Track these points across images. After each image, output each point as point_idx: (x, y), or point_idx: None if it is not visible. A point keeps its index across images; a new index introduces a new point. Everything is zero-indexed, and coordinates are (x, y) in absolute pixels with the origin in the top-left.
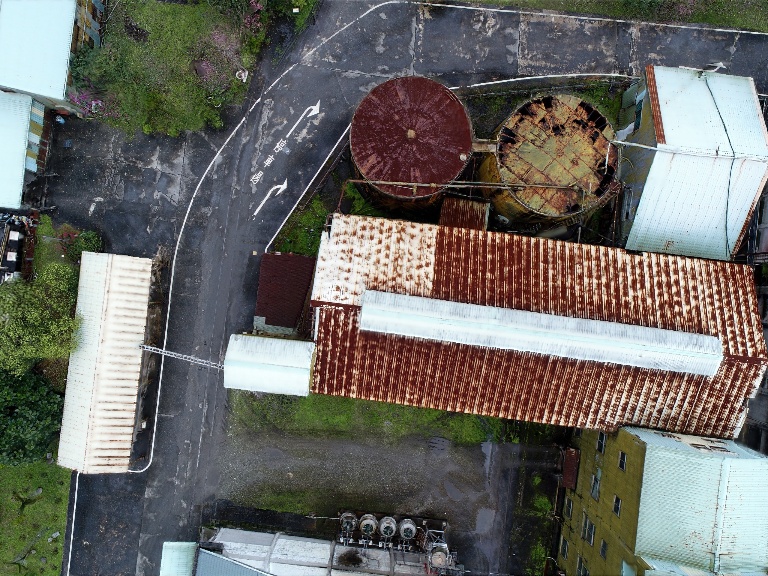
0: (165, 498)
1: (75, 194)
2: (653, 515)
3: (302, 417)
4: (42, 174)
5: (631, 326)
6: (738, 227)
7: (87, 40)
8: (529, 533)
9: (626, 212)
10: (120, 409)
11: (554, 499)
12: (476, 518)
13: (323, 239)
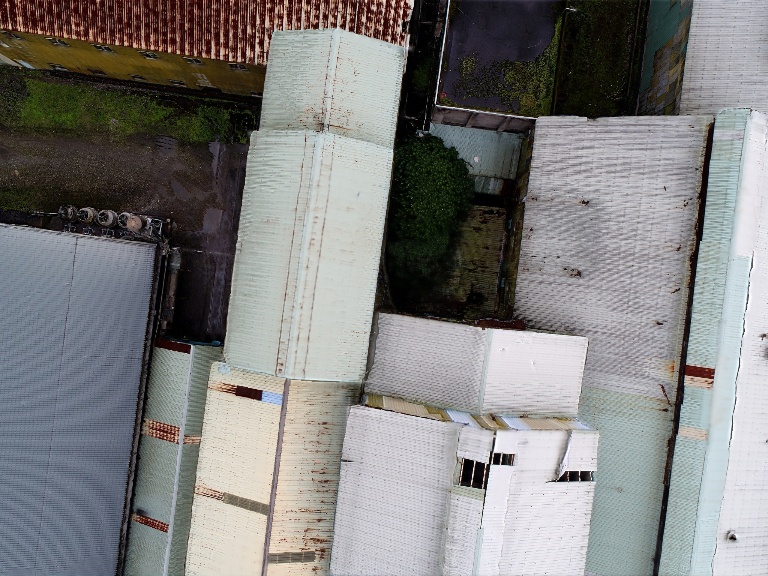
0: None
1: None
2: (275, 99)
3: (28, 115)
4: None
5: None
6: None
7: None
8: None
9: None
10: None
11: None
12: (203, 218)
13: None
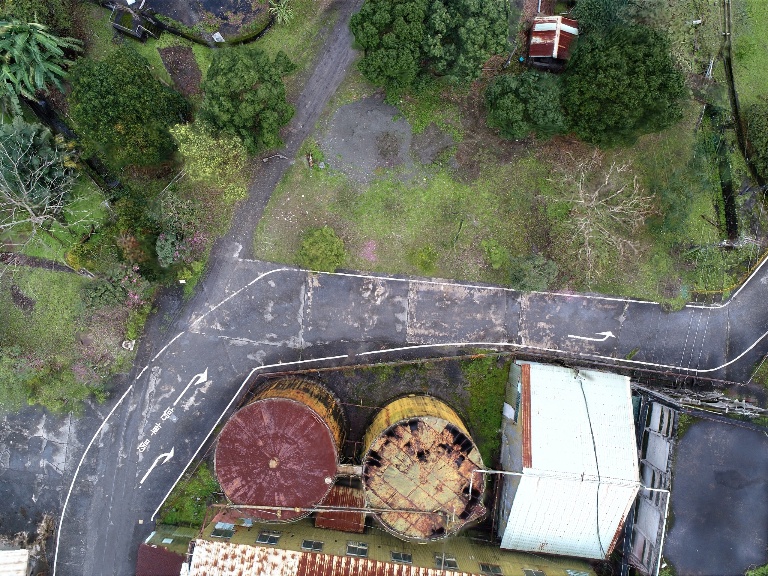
0: None
1: None
2: None
3: None
4: None
5: None
6: (610, 534)
7: None
8: None
9: (502, 509)
10: None
11: None
12: None
13: (183, 572)
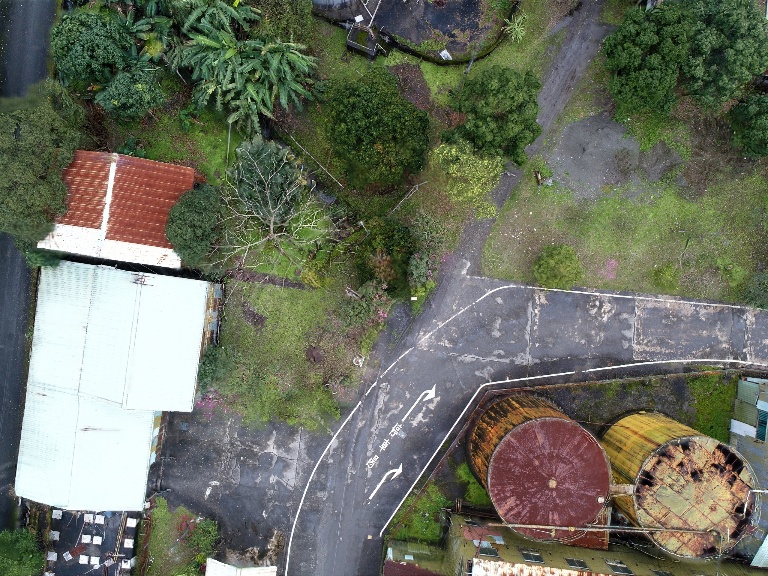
0: None
1: (191, 477)
2: None
3: None
4: (159, 459)
5: None
6: None
7: (209, 335)
8: None
9: None
10: None
11: None
12: None
13: None
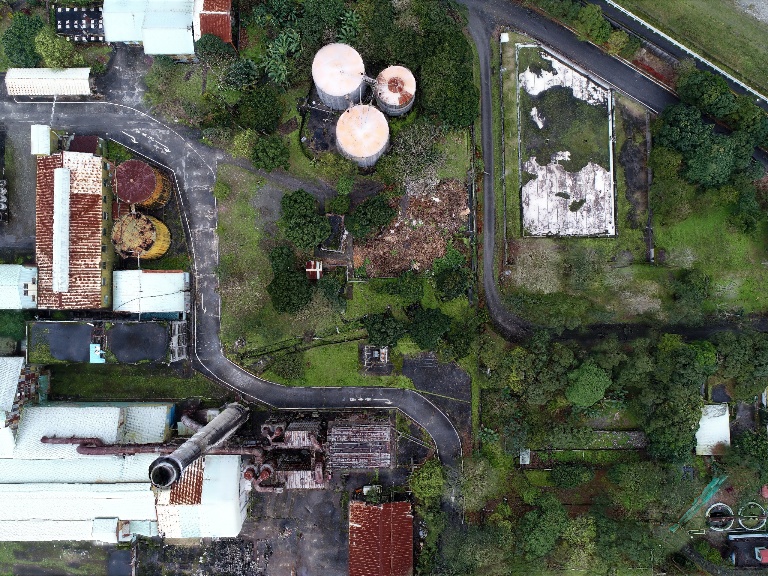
0: (5, 110)
1: (122, 60)
2: None
3: None
4: (128, 46)
5: (66, 260)
6: (123, 309)
7: (177, 58)
8: (8, 257)
9: None
10: (32, 89)
11: (23, 265)
12: (11, 235)
13: (90, 154)
